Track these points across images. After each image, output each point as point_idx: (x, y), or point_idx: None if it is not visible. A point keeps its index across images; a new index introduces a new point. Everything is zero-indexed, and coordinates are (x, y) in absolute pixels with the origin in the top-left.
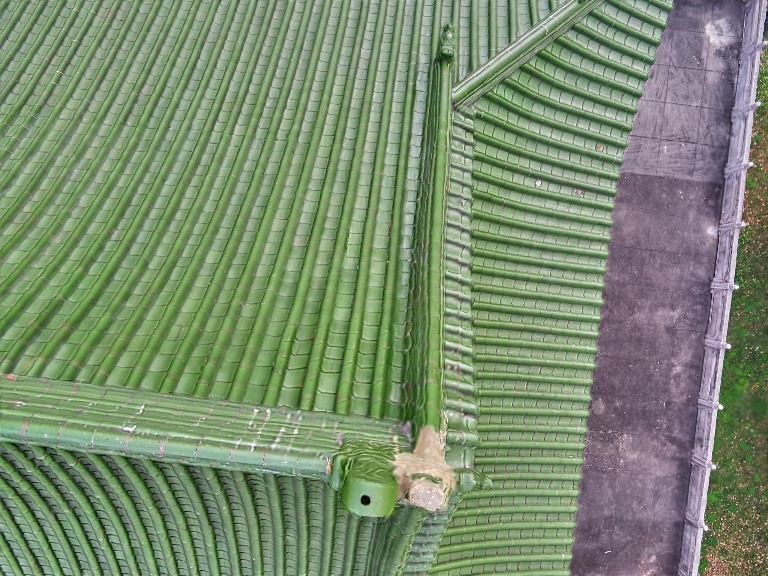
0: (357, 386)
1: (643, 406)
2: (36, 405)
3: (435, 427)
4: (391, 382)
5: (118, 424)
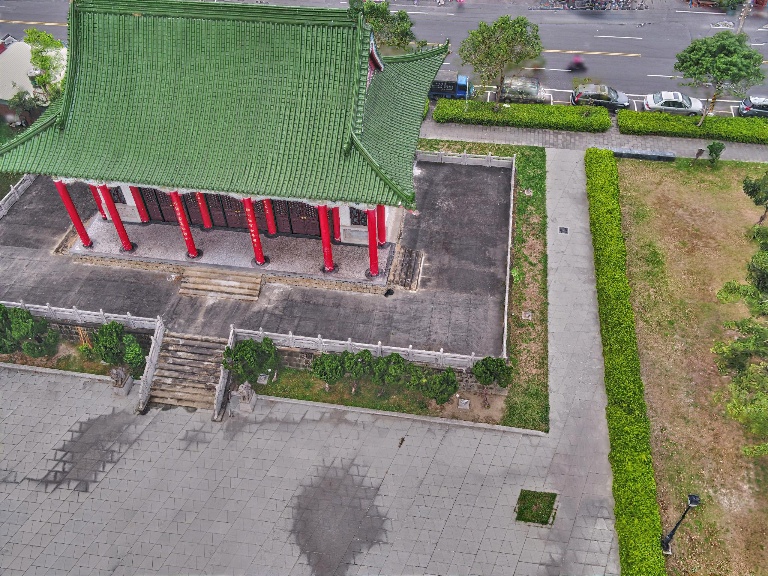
0: (85, 20)
1: (54, 184)
2: (124, 4)
3: (70, 4)
4: (80, 21)
5: (111, 0)
